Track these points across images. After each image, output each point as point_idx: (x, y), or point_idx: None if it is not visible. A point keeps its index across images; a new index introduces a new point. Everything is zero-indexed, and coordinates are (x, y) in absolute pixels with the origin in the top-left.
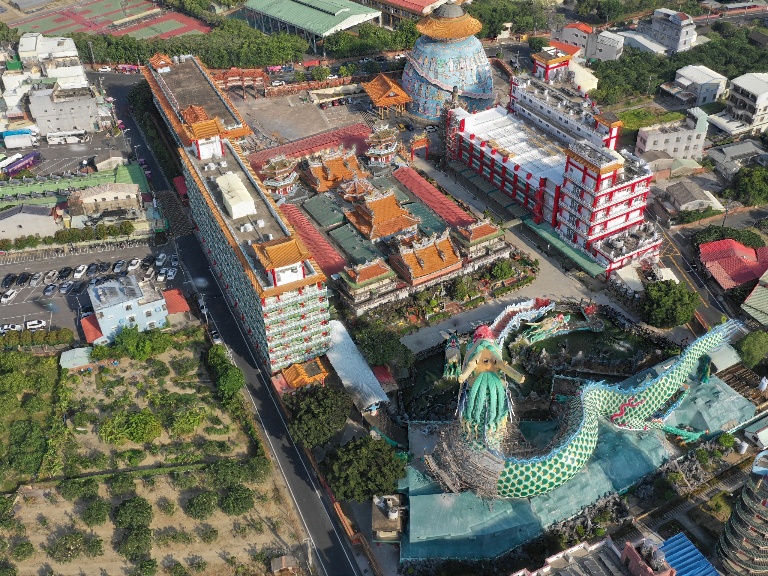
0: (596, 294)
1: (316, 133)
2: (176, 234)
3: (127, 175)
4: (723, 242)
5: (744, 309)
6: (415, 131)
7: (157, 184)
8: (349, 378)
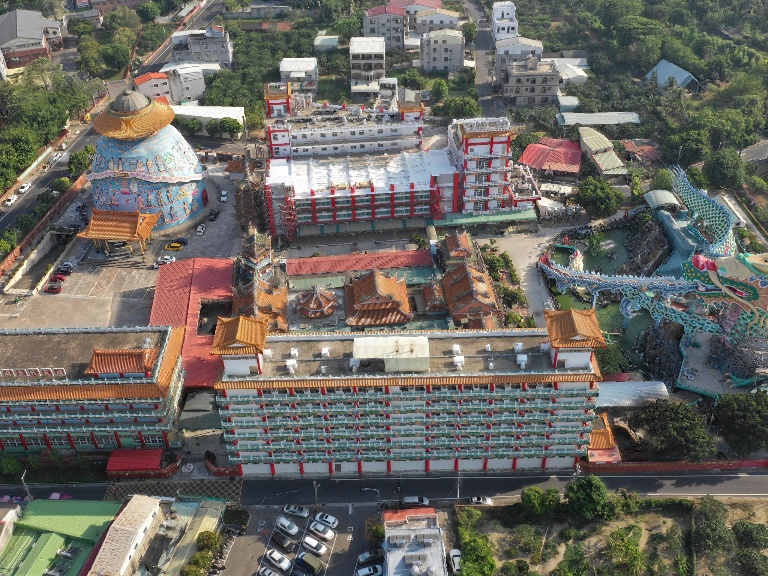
0: (542, 232)
1: (111, 313)
2: (232, 500)
3: (53, 519)
4: (529, 149)
5: (608, 174)
6: (190, 242)
7: (81, 498)
8: (625, 398)
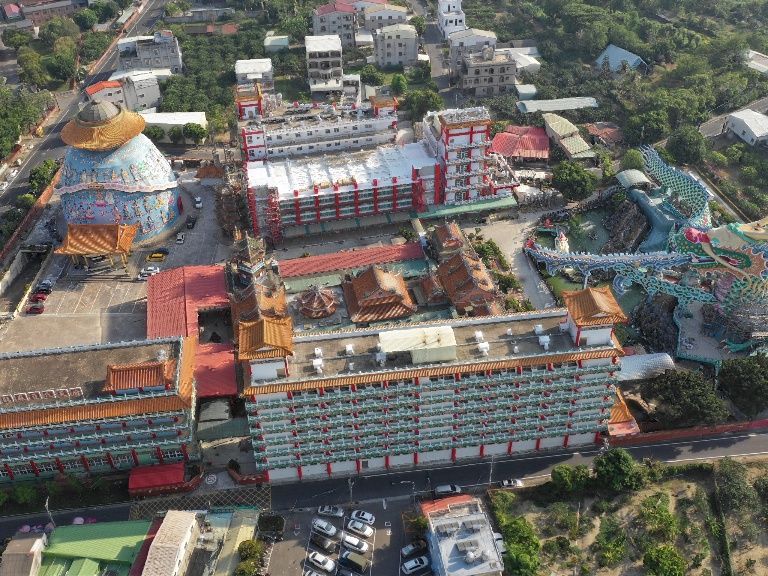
0: (522, 217)
1: (101, 330)
2: (263, 507)
3: (82, 544)
4: (498, 138)
5: (577, 157)
6: (171, 251)
7: (105, 520)
8: (634, 371)
